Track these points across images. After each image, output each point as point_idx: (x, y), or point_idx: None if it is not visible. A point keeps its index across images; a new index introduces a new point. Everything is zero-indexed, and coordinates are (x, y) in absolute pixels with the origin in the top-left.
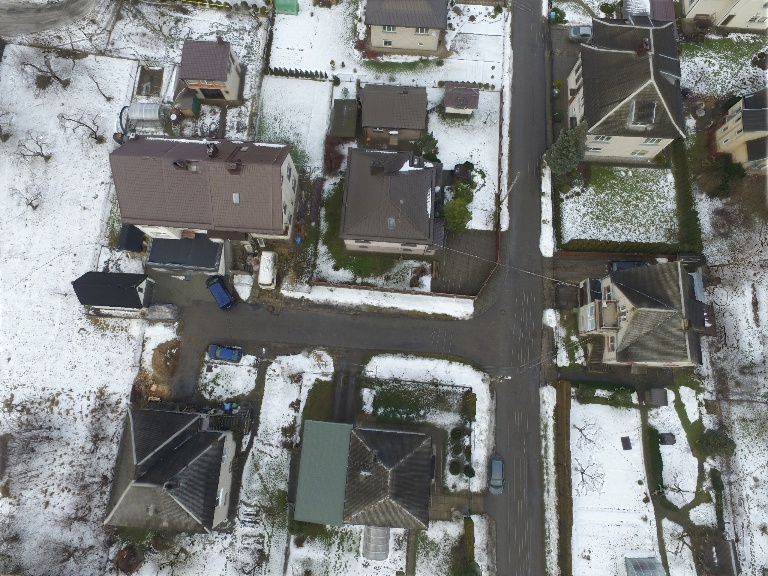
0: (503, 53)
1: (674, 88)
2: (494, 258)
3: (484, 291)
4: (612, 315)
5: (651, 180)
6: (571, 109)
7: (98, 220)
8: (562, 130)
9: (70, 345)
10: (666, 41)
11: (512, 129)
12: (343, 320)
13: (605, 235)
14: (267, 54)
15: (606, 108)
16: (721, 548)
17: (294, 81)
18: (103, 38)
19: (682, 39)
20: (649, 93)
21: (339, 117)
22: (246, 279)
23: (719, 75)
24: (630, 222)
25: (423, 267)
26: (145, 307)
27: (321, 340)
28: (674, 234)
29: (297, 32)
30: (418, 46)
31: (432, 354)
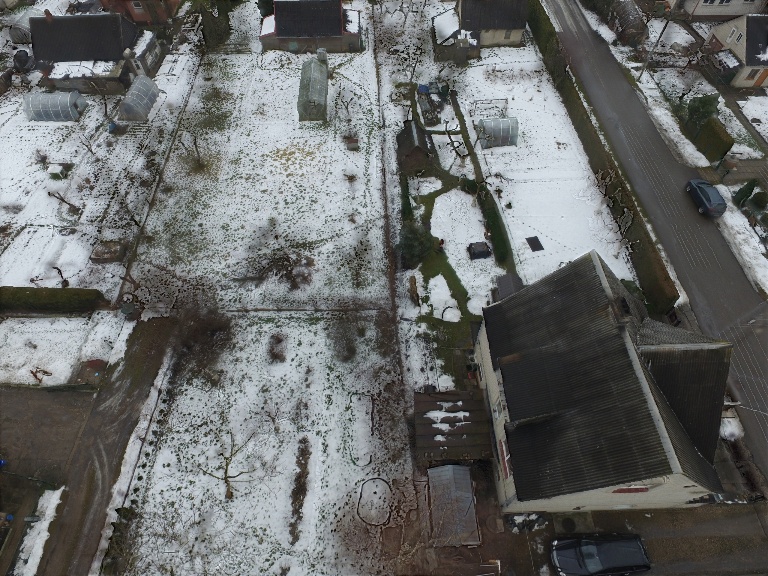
0: None
1: None
2: None
3: None
4: None
5: None
6: None
7: None
8: None
9: None
10: None
11: None
12: None
13: None
14: None
15: None
16: (424, 144)
17: None
18: None
19: None
20: None
21: None
22: None
23: None
24: None
25: None
26: None
27: None
28: None
29: None
30: None
31: None
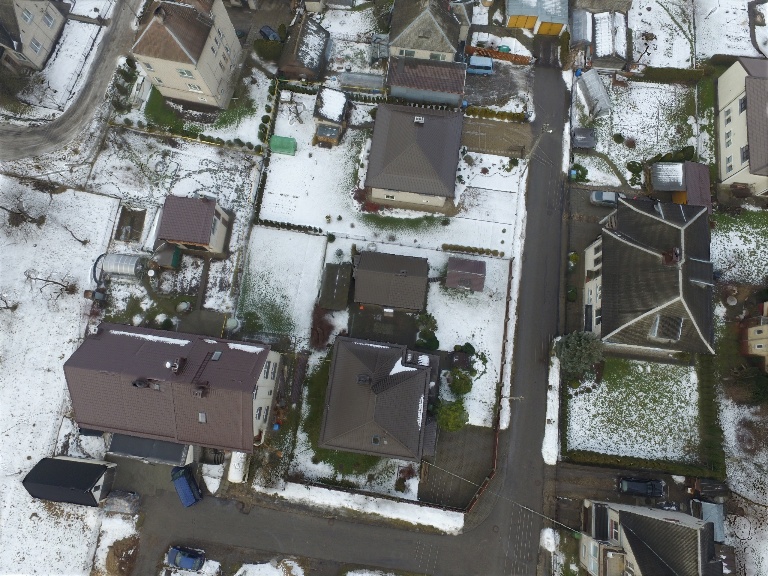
0: (516, 214)
1: (705, 292)
2: (490, 462)
3: (477, 501)
4: (618, 566)
5: (672, 379)
6: (587, 289)
7: (62, 385)
8: (575, 332)
9: (20, 532)
10: (699, 234)
11: (520, 306)
12: (318, 525)
13: (616, 443)
14: (258, 201)
15: (626, 315)
16: None
17: (285, 233)
18: (84, 170)
19: (716, 209)
20: (676, 309)
21: (330, 285)
22: (216, 468)
23: (755, 255)
24: (645, 429)
25: (411, 467)
26: (103, 498)
27: (293, 548)
28: (694, 447)
29: (293, 176)
30: (423, 202)
31: (414, 574)
